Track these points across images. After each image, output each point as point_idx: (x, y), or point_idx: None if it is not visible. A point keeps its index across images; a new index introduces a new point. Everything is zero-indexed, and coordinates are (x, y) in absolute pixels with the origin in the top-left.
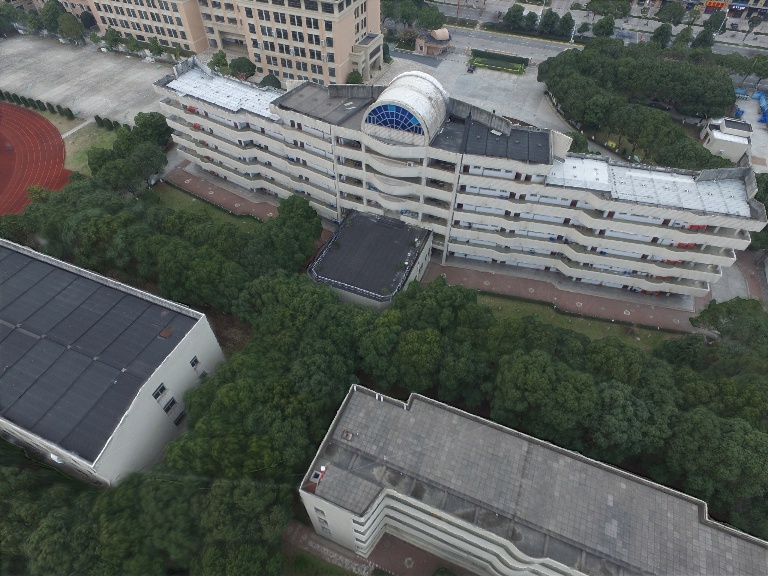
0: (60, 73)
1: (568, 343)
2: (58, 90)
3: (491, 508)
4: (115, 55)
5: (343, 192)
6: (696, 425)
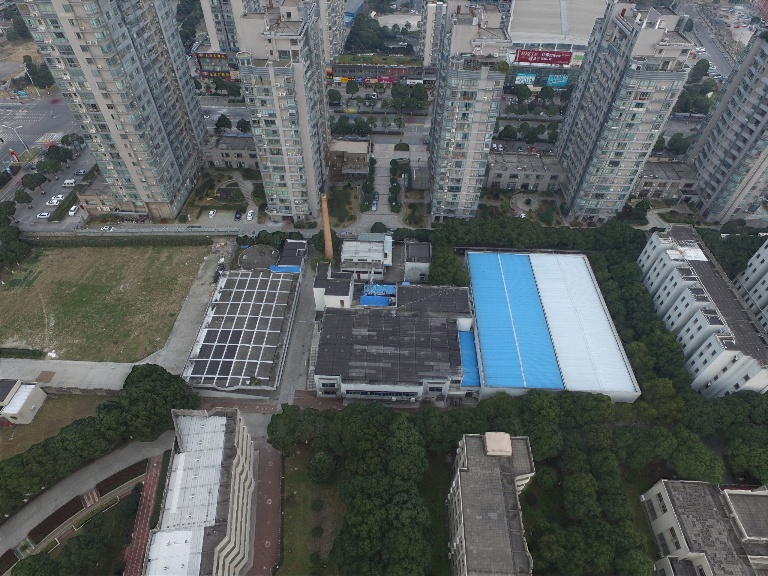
0: None
1: (363, 552)
2: None
3: None
4: None
5: None
6: (406, 467)
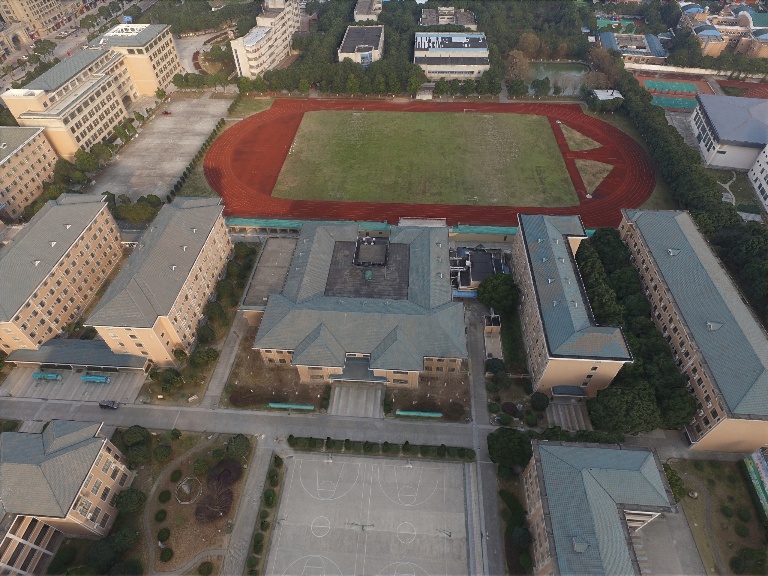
0: (162, 151)
1: None
2: (188, 142)
3: (369, 8)
4: (129, 144)
5: (287, 36)
6: None
